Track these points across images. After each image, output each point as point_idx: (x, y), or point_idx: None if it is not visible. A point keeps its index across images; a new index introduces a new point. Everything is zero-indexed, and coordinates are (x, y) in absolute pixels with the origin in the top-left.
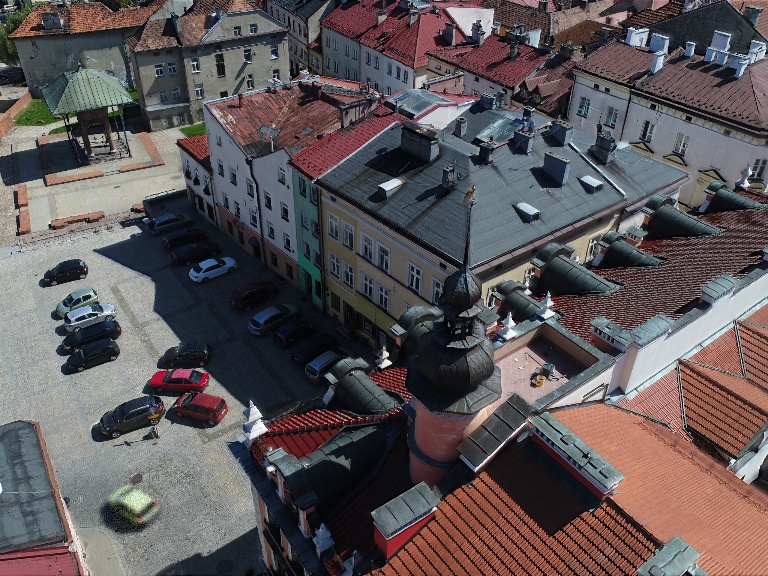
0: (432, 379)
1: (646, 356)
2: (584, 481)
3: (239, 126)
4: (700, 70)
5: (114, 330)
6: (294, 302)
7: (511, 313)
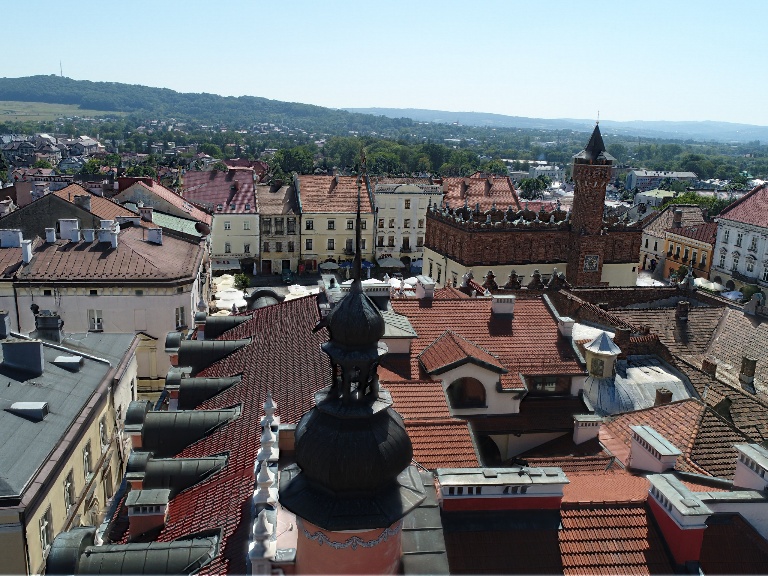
0: (371, 478)
1: None
2: (533, 504)
3: None
4: (74, 250)
5: None
6: None
7: (164, 487)
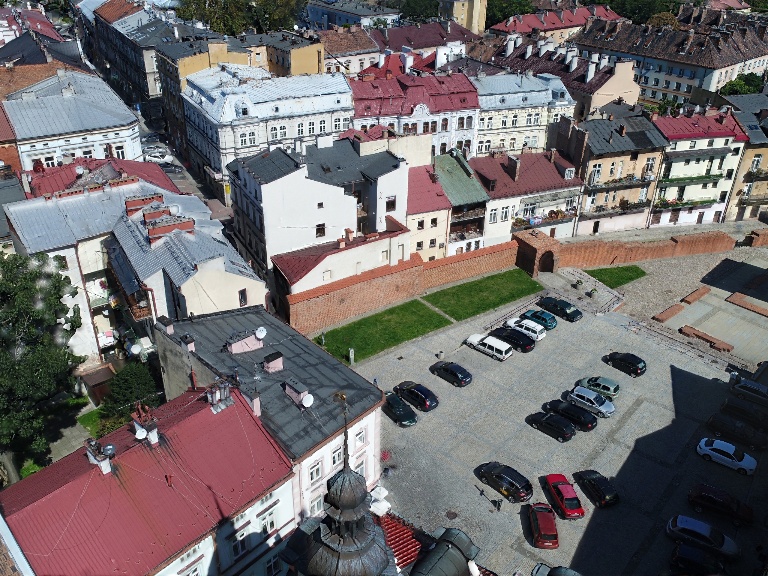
0: None
1: None
2: None
3: None
4: None
5: (586, 423)
6: (748, 548)
7: None
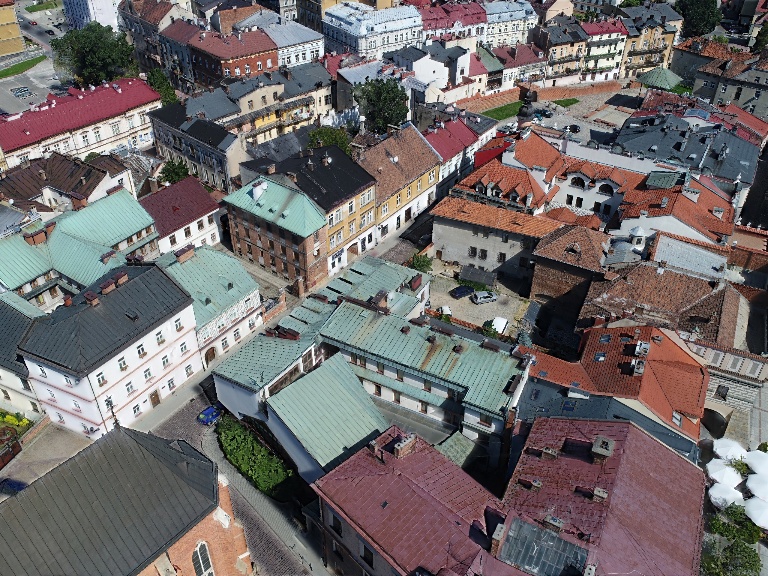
0: None
1: (572, 146)
2: None
3: (652, 101)
4: None
5: None
6: None
7: None
